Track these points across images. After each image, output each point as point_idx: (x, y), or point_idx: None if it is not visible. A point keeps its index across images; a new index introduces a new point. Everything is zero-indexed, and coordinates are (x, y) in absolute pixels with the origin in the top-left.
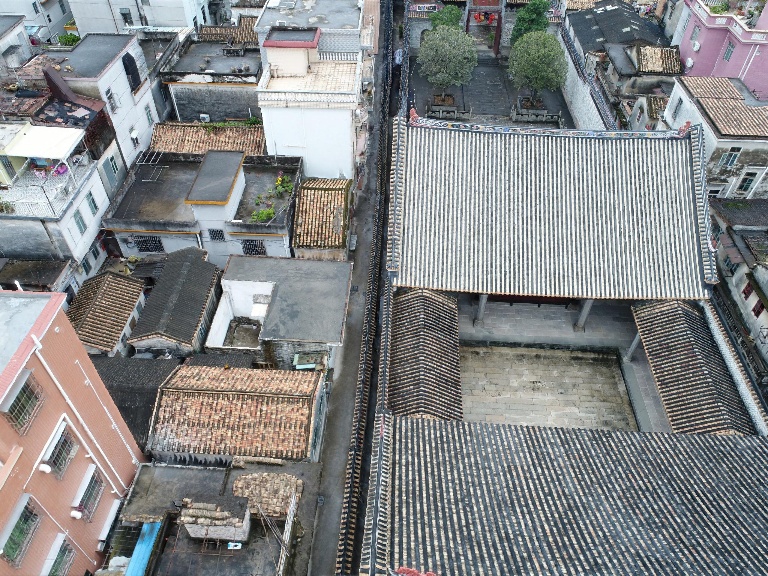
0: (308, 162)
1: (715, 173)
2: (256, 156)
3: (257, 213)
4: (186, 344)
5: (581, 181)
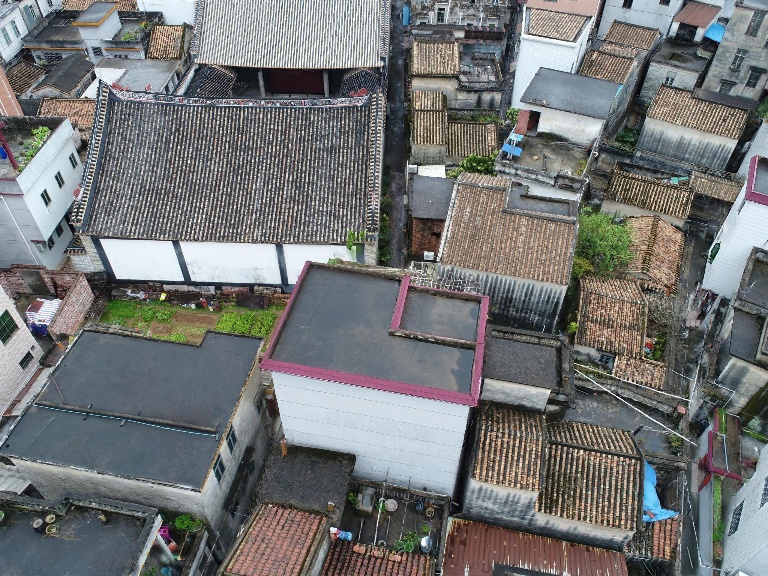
0: (167, 17)
1: (419, 9)
2: (131, 12)
3: (124, 38)
4: (66, 93)
5: (315, 3)
